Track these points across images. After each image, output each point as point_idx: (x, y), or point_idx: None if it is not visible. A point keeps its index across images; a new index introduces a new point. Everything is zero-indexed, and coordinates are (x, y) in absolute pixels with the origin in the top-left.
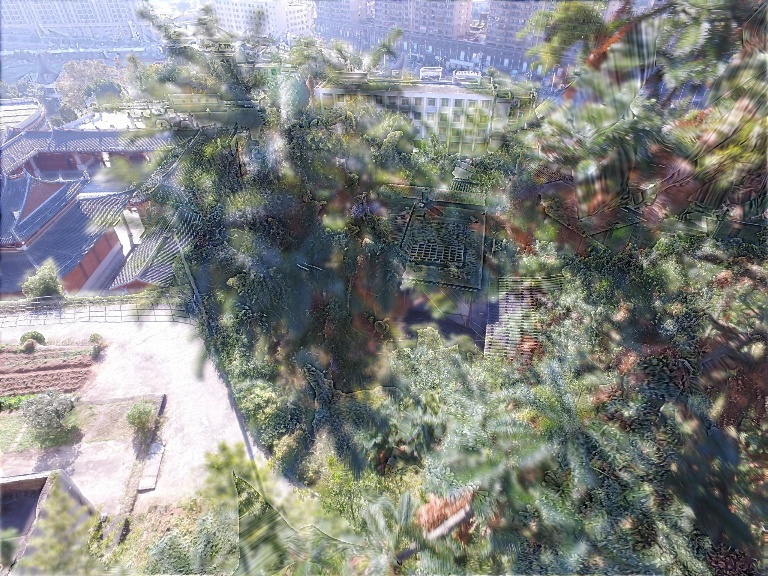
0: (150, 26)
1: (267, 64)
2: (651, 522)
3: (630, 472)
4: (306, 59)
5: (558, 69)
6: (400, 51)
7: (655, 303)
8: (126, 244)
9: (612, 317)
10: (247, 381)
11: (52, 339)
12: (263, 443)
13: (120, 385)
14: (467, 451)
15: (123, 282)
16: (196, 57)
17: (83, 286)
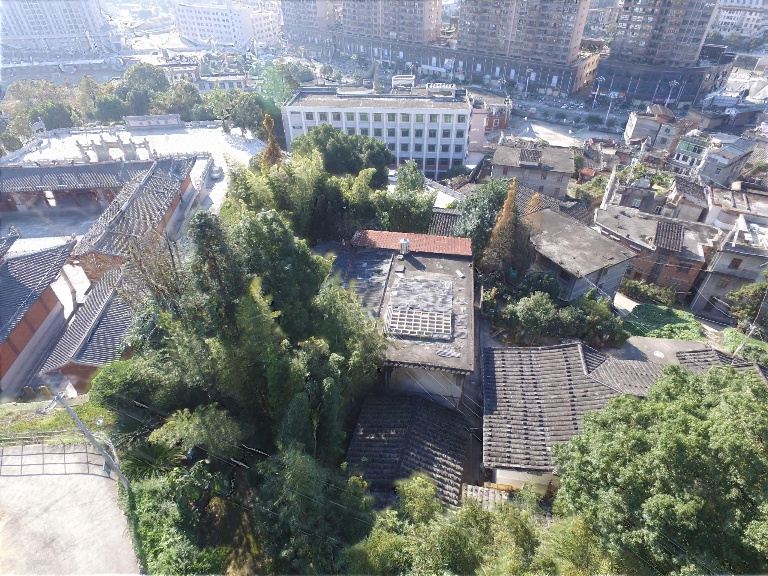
0: (109, 36)
1: (232, 77)
2: None
3: None
4: (271, 75)
5: (531, 73)
6: (371, 57)
7: (731, 494)
8: (68, 304)
9: (674, 515)
10: None
11: None
12: None
13: None
14: None
15: (56, 365)
16: (154, 74)
17: (13, 364)
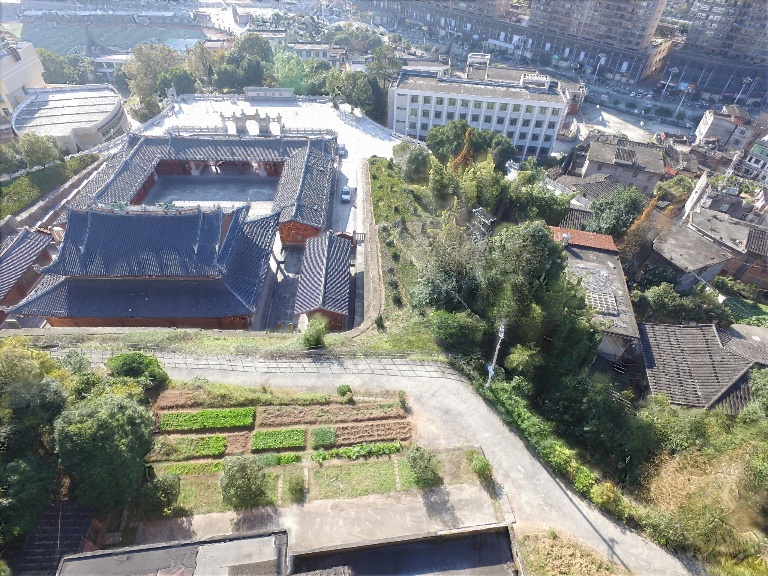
0: None
1: (317, 45)
2: None
3: None
4: (377, 55)
5: (601, 57)
6: (436, 27)
7: None
8: (271, 260)
9: None
10: (545, 439)
11: (351, 388)
12: (578, 490)
13: (439, 435)
14: None
15: (307, 309)
16: (262, 45)
17: None
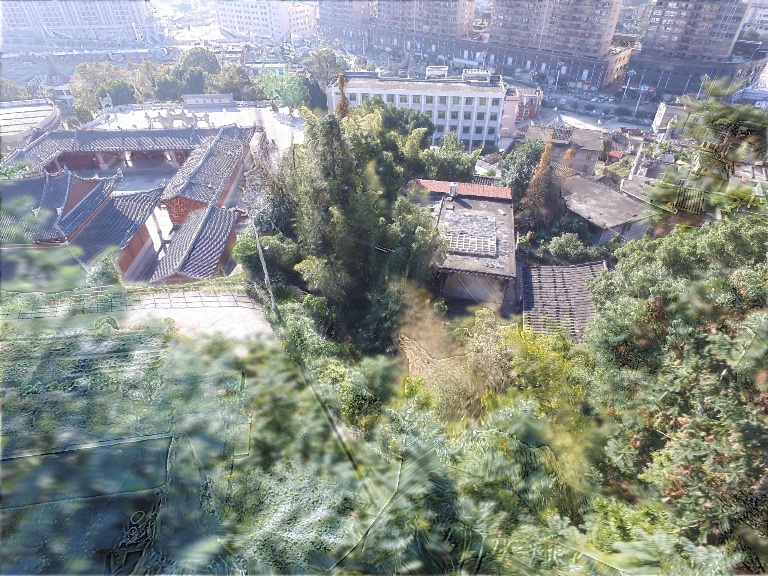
0: (153, 28)
1: (274, 64)
2: (710, 479)
3: (691, 433)
4: (317, 59)
5: (562, 67)
6: (403, 50)
7: (709, 279)
8: (156, 240)
9: (670, 292)
10: (321, 358)
11: (122, 324)
12: (344, 413)
13: (198, 364)
14: (532, 420)
15: (163, 275)
16: (207, 58)
17: None
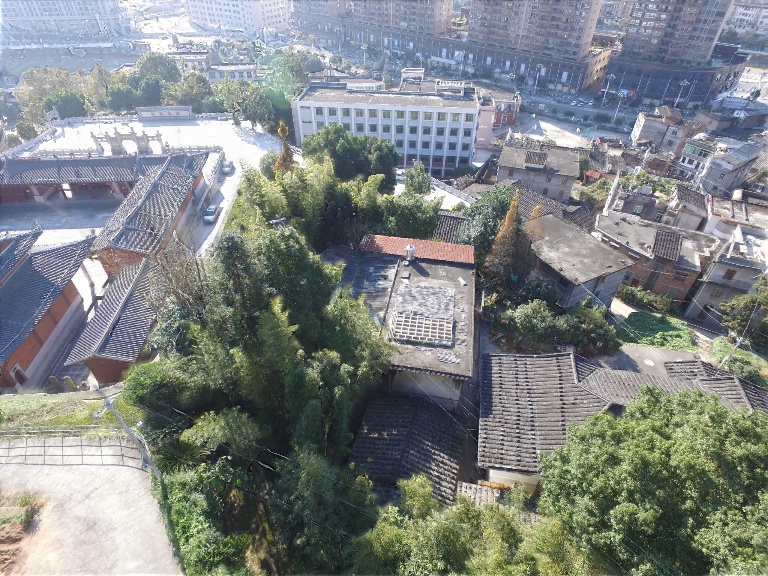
0: (119, 19)
1: (242, 66)
2: None
3: None
4: (282, 68)
5: (541, 68)
6: (380, 47)
7: (686, 505)
8: (87, 296)
9: (636, 522)
10: (205, 573)
11: None
12: None
13: (55, 571)
14: None
15: (80, 357)
16: (165, 64)
17: (37, 354)
